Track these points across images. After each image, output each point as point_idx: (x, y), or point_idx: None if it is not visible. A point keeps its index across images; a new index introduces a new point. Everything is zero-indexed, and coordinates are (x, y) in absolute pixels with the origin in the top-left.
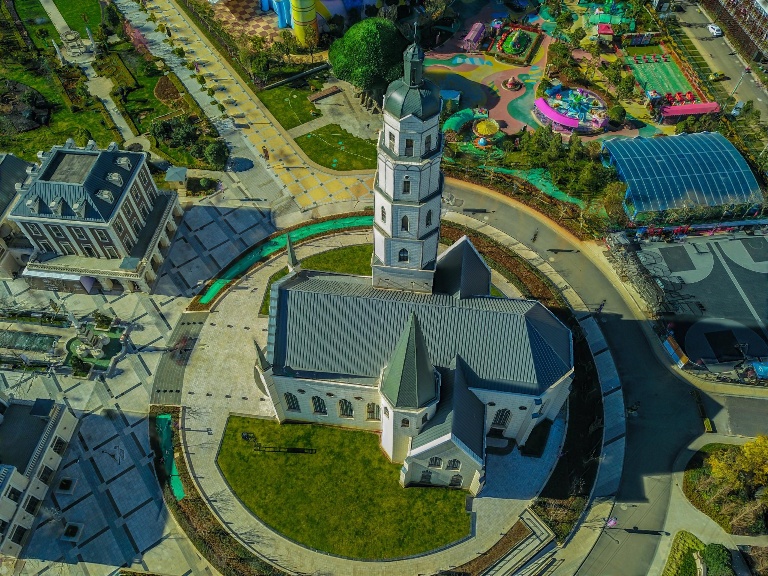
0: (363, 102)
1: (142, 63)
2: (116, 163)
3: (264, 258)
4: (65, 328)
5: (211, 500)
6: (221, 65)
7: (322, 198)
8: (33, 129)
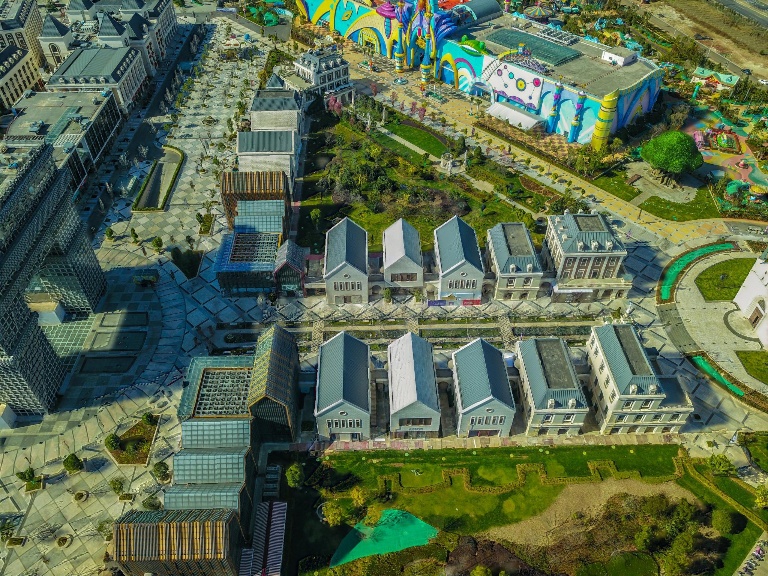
0: (662, 182)
1: (499, 170)
2: (606, 220)
3: (682, 272)
4: (593, 321)
5: (762, 392)
6: (551, 167)
7: (684, 237)
8: (465, 215)
